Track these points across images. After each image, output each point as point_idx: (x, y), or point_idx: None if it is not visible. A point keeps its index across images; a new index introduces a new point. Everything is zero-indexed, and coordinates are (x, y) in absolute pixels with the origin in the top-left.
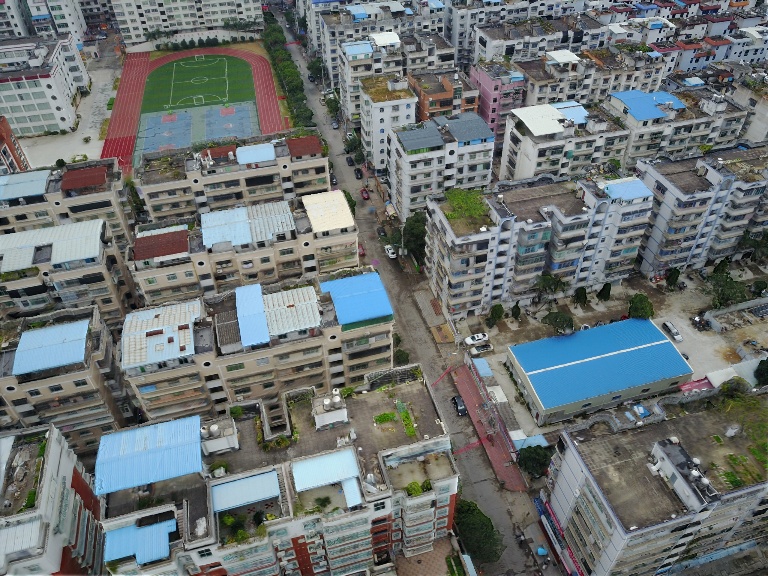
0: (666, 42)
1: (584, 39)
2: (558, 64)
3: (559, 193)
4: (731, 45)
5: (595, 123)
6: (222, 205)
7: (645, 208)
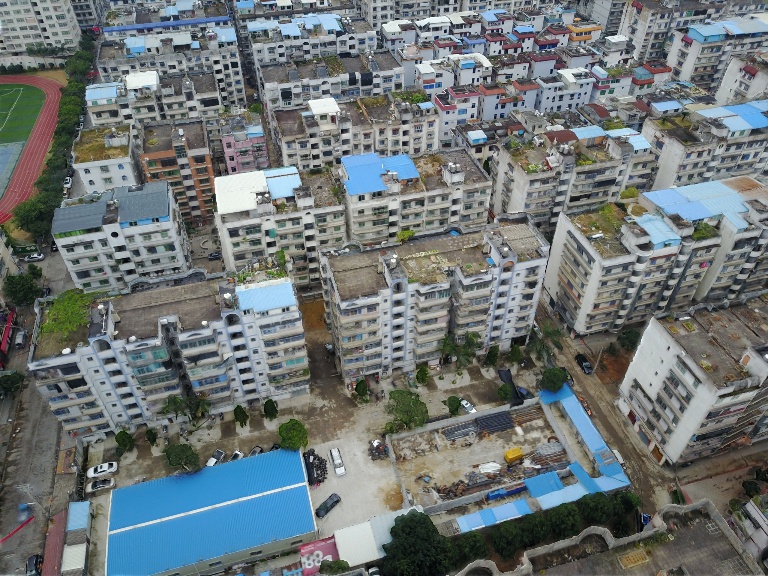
0: (468, 86)
1: (375, 81)
2: (313, 116)
3: (198, 296)
4: (542, 90)
5: (297, 198)
6: None
7: (290, 319)
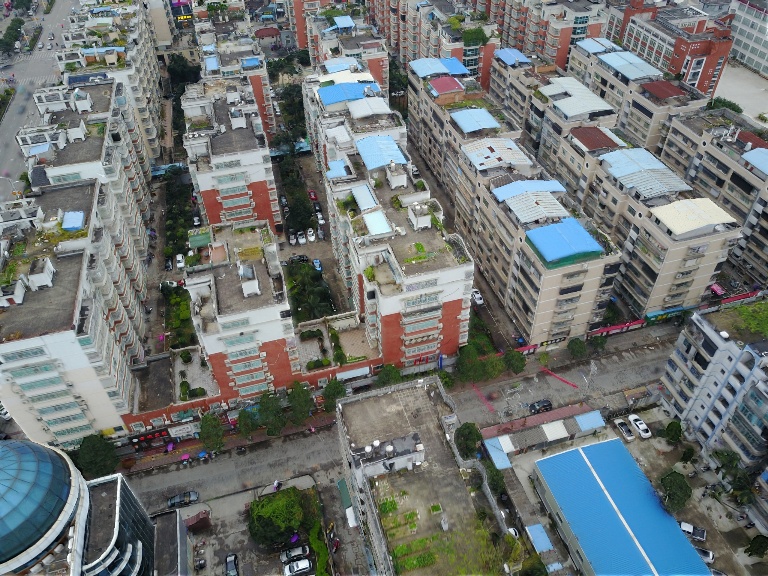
0: None
1: None
2: None
3: None
4: None
5: None
6: (705, 180)
7: None
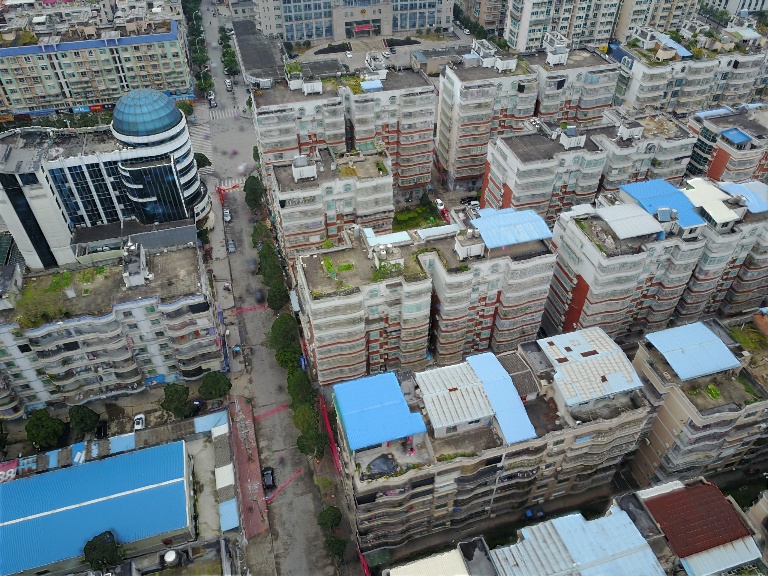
0: None
1: None
2: None
3: None
4: None
5: None
6: None
7: None
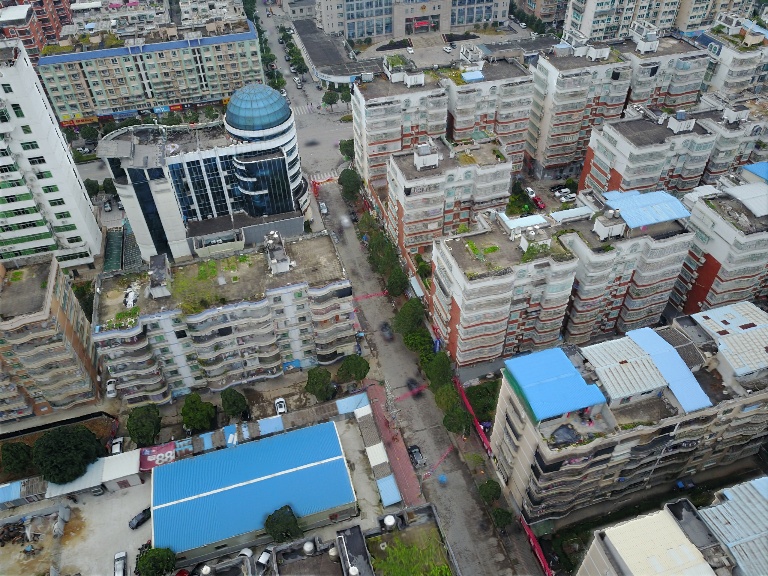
0: None
1: None
2: None
3: None
4: None
5: None
6: None
7: None
